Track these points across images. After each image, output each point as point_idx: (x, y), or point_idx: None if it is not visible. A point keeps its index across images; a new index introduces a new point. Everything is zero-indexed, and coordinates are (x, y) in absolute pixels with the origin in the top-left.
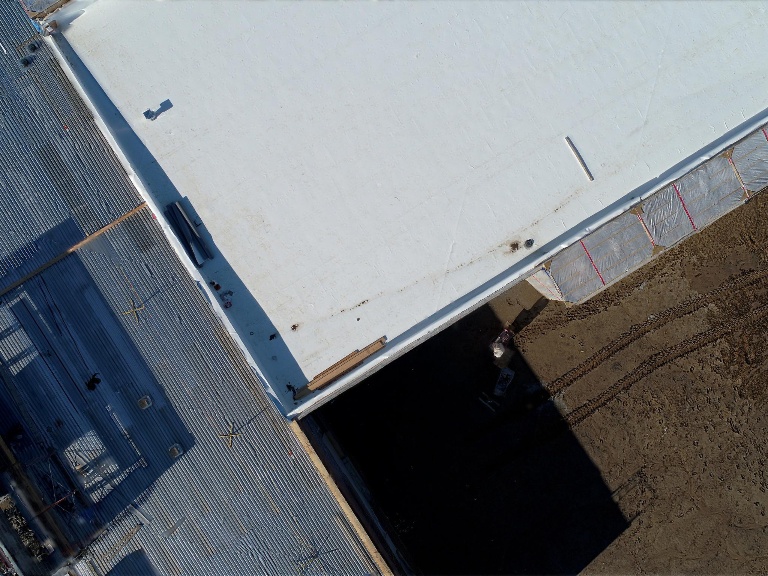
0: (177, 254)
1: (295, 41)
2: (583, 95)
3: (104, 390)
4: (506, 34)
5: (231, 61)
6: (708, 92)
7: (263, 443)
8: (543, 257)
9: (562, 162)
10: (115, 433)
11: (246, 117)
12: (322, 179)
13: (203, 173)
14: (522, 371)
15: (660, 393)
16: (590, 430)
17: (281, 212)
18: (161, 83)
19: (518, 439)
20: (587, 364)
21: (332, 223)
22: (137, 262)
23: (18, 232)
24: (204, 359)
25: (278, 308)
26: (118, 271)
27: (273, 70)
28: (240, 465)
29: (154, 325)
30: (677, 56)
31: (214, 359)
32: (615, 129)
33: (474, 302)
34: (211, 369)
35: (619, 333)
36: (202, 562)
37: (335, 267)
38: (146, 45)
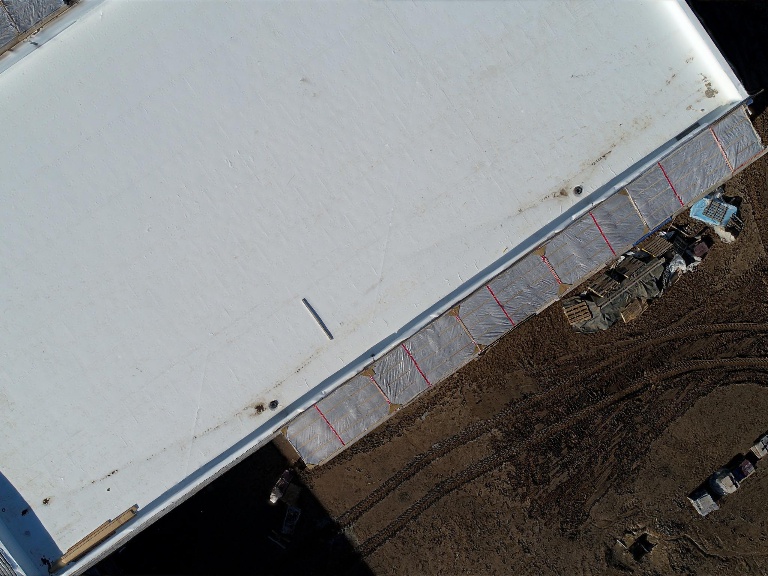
0: None
1: (26, 223)
2: (317, 257)
3: None
4: (236, 203)
5: None
6: (440, 246)
7: None
8: (280, 422)
9: (301, 323)
10: None
11: None
12: (63, 355)
13: None
14: (311, 506)
15: (449, 519)
16: (383, 560)
17: (24, 390)
18: None
19: (311, 573)
20: (375, 495)
21: (76, 397)
22: None
23: None
24: None
25: (28, 484)
26: None
27: (6, 252)
28: None
29: None
30: (407, 213)
31: None
32: (351, 288)
33: (216, 470)
34: None
35: (404, 463)
36: None
37: (82, 440)
38: None
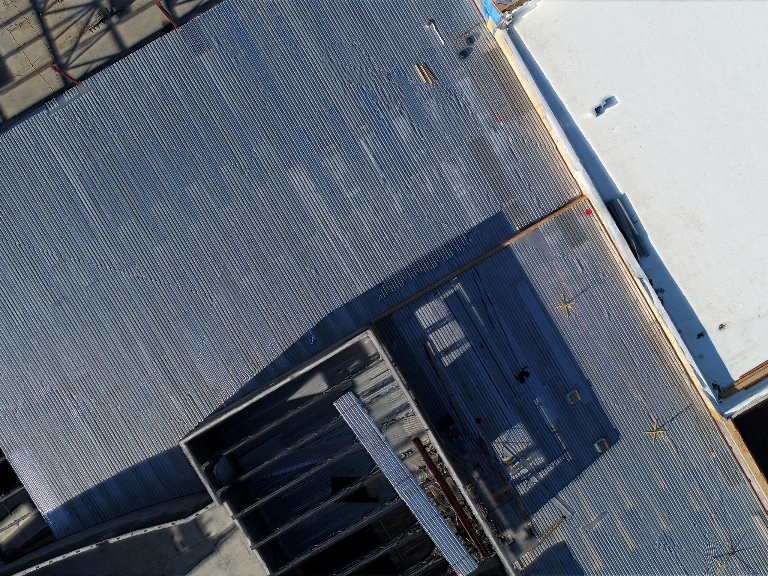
0: (608, 250)
1: (742, 40)
2: None
3: (532, 383)
4: None
5: (678, 59)
6: None
7: (685, 440)
8: None
9: None
10: (542, 426)
11: (688, 115)
12: (758, 179)
13: (643, 170)
14: None
15: None
16: None
17: (717, 211)
18: (608, 79)
19: None
20: None
21: (766, 224)
22: (569, 257)
23: (450, 224)
24: (631, 355)
25: (707, 307)
26: (550, 266)
27: (718, 69)
28: (662, 461)
29: (583, 320)
30: None
31: (641, 356)
32: None
33: None
34: (637, 366)
35: None
36: (621, 556)
37: (766, 268)
38: (595, 41)
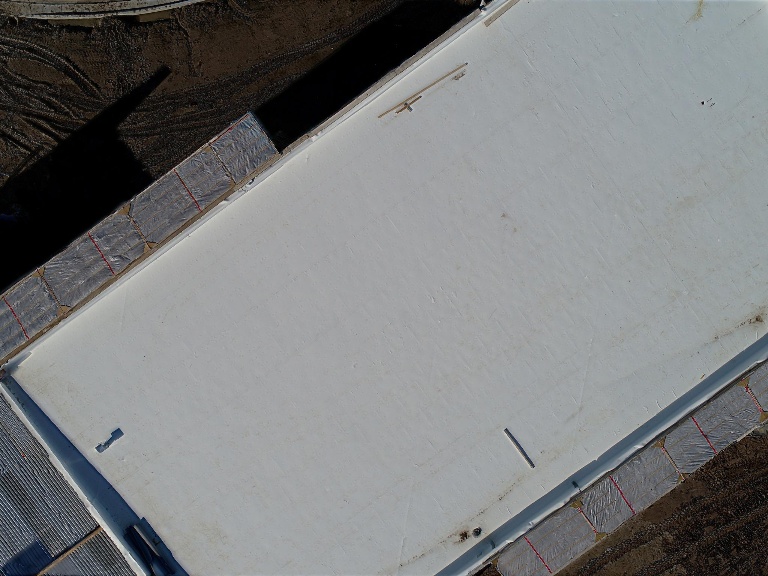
0: None
1: (236, 363)
2: (518, 388)
3: None
4: (439, 337)
5: (176, 387)
6: (639, 375)
7: None
8: (490, 553)
9: (503, 453)
10: None
11: (195, 438)
12: (273, 489)
13: (158, 494)
14: None
15: None
16: None
17: (236, 524)
18: (110, 414)
19: None
20: None
21: (286, 530)
22: None
23: None
24: None
25: None
26: None
27: (217, 392)
28: None
29: None
30: (606, 343)
31: None
32: (551, 417)
33: None
34: None
35: (578, 568)
36: None
37: (292, 571)
38: (93, 379)
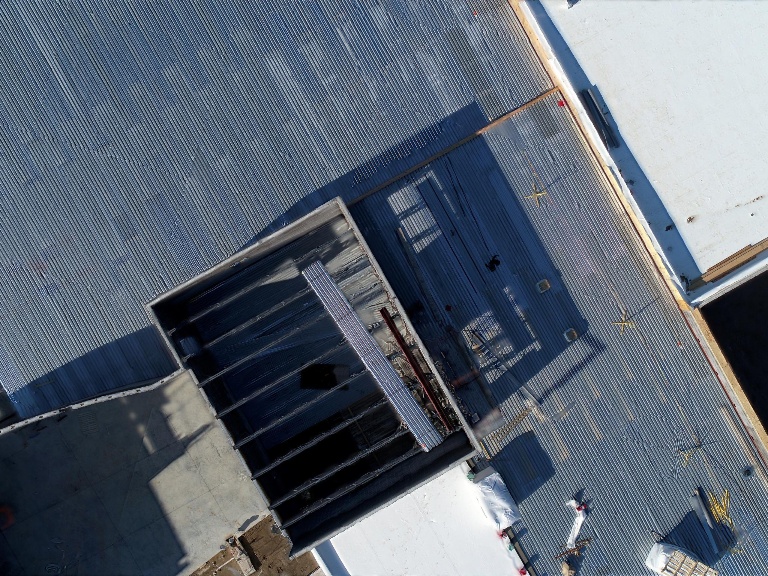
0: (579, 142)
1: None
2: None
3: (503, 272)
4: None
5: None
6: None
7: (653, 332)
8: None
9: None
10: (512, 315)
11: (658, 10)
12: (726, 75)
13: (613, 63)
14: None
15: None
16: None
17: (686, 105)
18: None
19: None
20: None
21: (733, 119)
22: (540, 148)
23: (424, 113)
24: (600, 247)
25: (676, 200)
26: (522, 156)
27: None
28: (630, 353)
29: (554, 211)
30: None
31: (610, 247)
32: None
33: None
34: (606, 257)
35: None
36: (589, 447)
37: (733, 162)
38: None
